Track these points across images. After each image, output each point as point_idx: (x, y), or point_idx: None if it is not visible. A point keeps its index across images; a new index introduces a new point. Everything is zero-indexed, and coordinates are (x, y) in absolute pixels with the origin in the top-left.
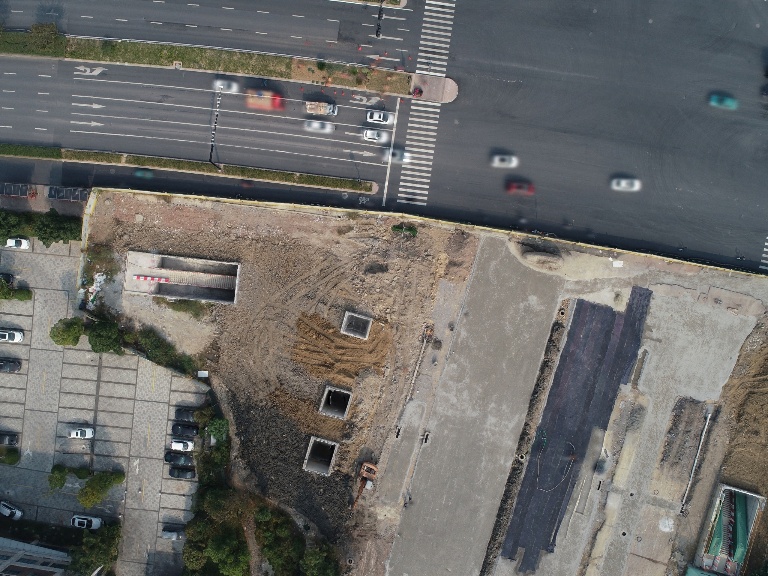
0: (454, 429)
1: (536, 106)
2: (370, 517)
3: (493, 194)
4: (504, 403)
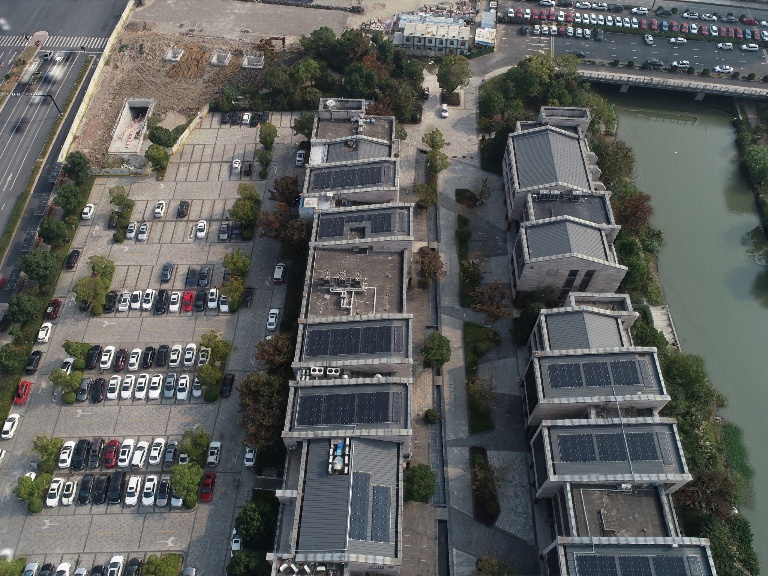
0: (241, 22)
1: (61, 7)
2: (292, 45)
3: (107, 17)
4: (227, 8)
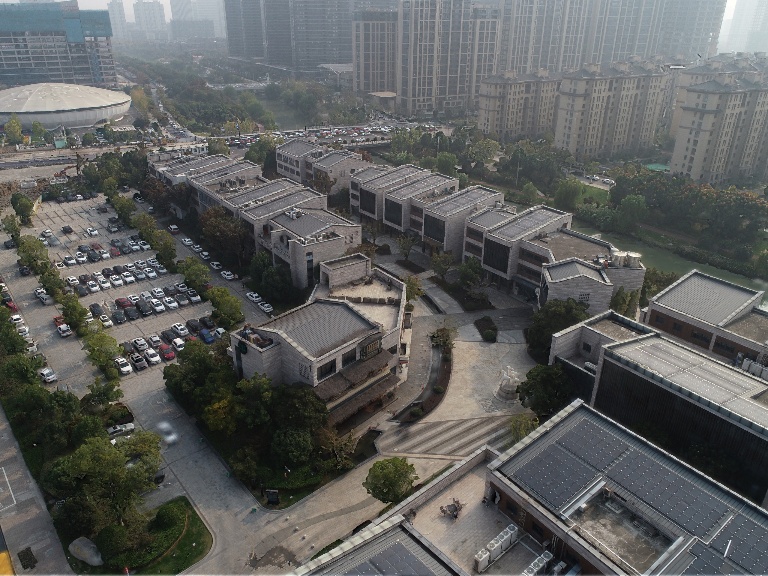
0: None
1: None
2: None
3: None
4: (7, 172)
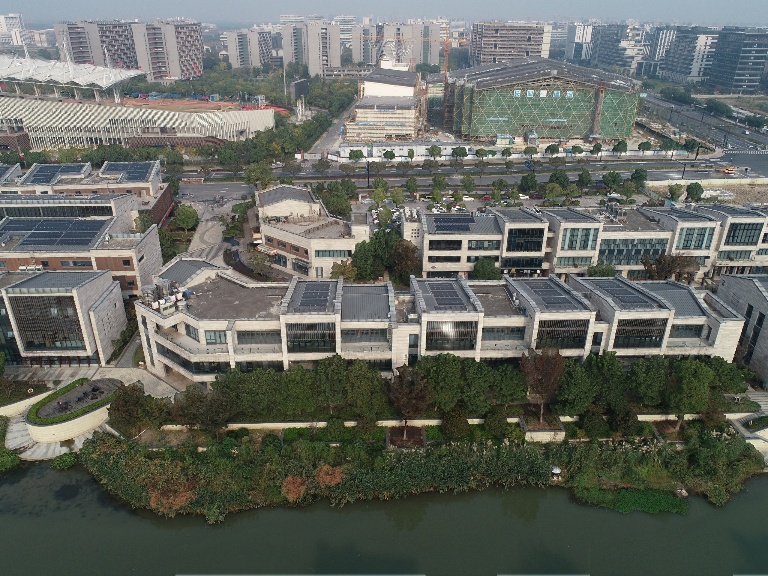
0: None
1: None
2: None
3: None
4: None
